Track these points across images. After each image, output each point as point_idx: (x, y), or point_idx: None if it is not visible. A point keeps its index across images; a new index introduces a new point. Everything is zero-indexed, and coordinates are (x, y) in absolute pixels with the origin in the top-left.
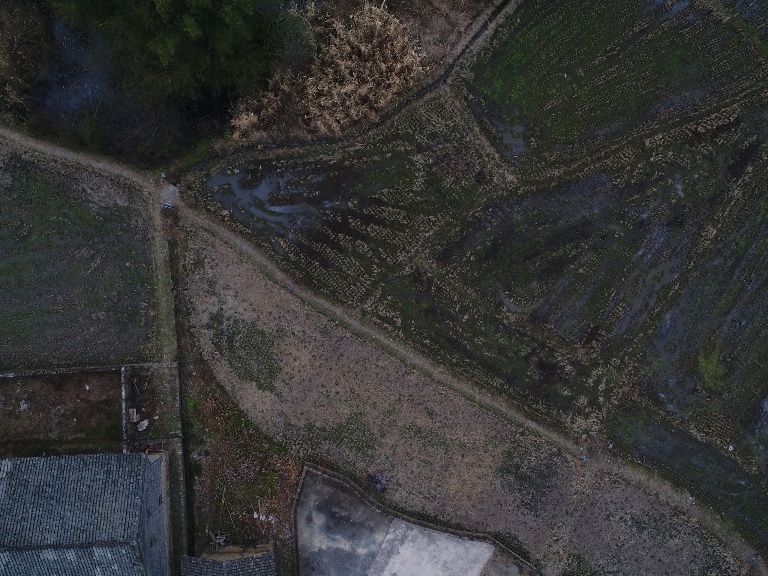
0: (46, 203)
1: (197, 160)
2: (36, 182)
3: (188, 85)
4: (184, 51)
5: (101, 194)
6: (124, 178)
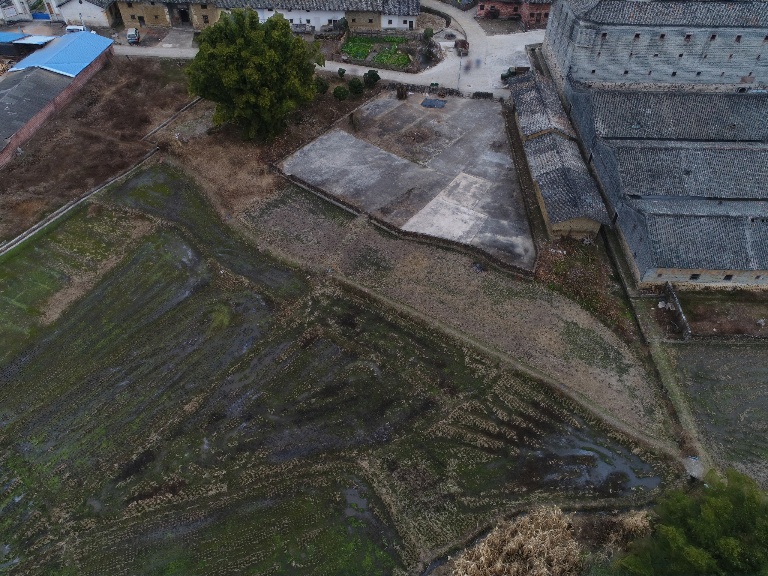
0: None
1: None
2: None
3: None
4: None
5: (763, 475)
6: None
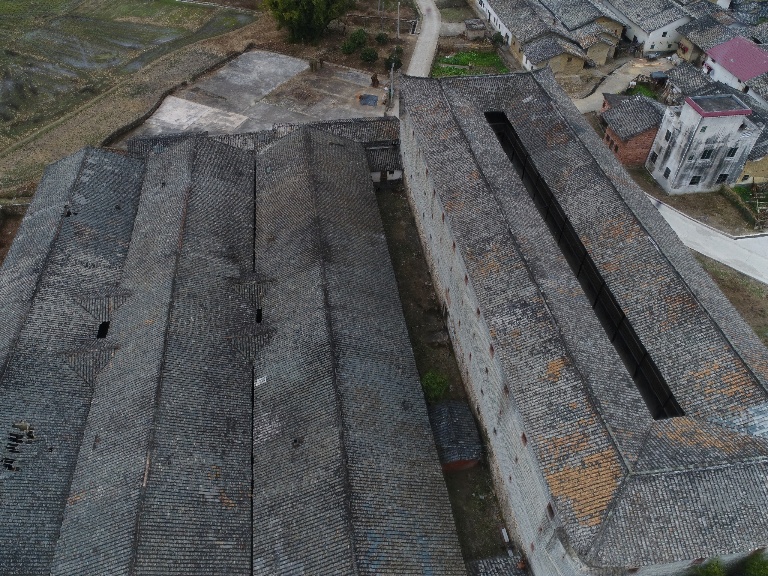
0: None
1: None
2: None
3: None
4: None
5: None
6: None
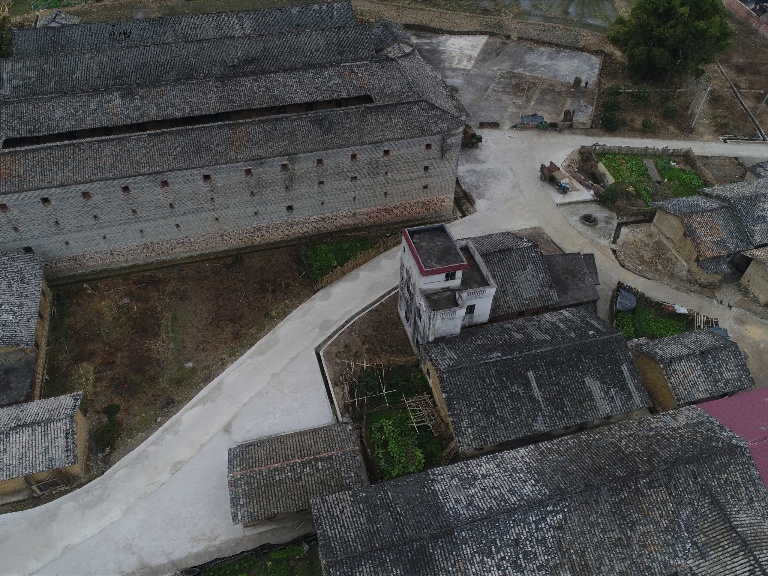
0: None
1: None
2: None
3: None
4: None
5: None
6: None
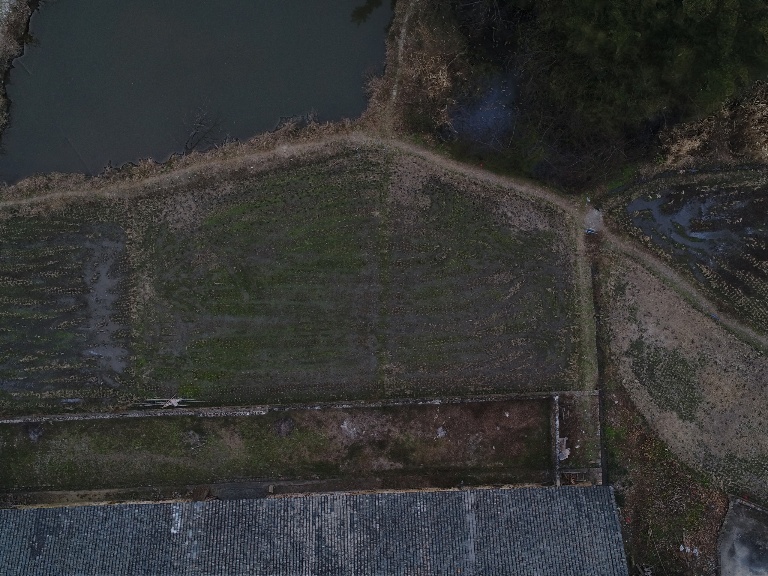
0: (465, 226)
1: (619, 184)
2: (455, 205)
3: None
4: None
5: (522, 218)
6: (547, 202)
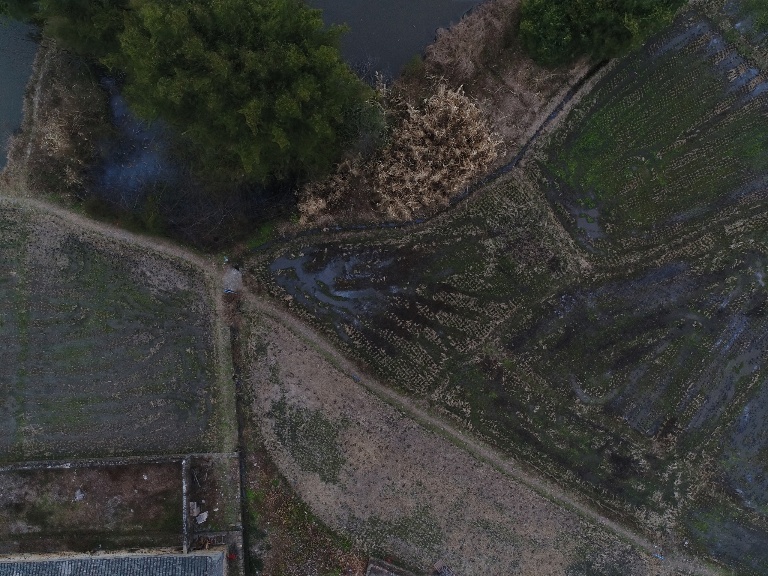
0: (104, 286)
1: (260, 243)
2: (94, 264)
3: (258, 174)
4: (263, 151)
5: (161, 277)
6: (185, 261)
